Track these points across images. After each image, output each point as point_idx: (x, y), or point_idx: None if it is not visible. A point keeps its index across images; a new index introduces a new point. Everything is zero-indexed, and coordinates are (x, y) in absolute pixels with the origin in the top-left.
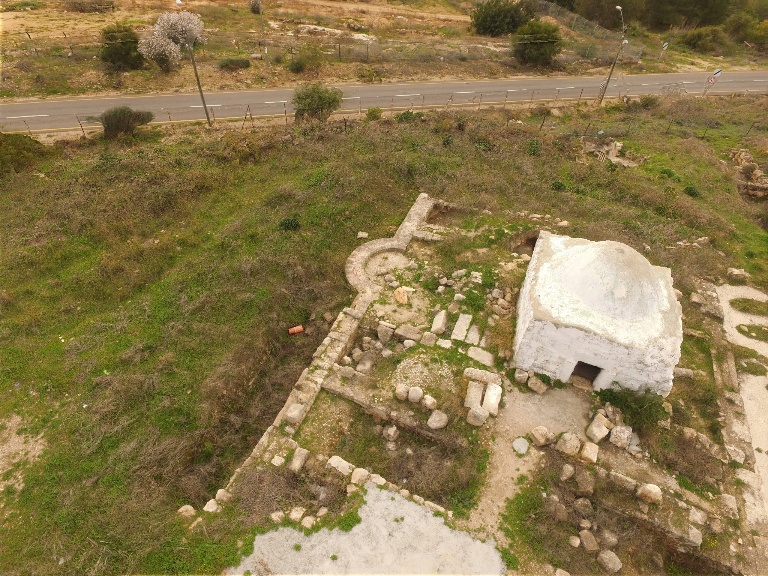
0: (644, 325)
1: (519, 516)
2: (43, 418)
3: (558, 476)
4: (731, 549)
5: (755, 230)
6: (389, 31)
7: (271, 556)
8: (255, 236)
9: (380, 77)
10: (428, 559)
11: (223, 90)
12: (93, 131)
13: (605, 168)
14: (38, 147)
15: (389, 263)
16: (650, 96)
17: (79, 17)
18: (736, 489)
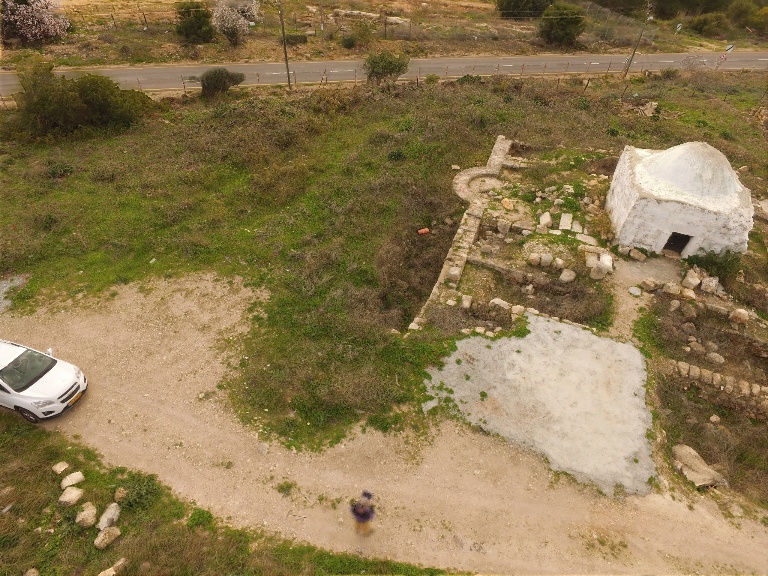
0: (726, 200)
1: (645, 330)
2: (260, 277)
3: (667, 308)
4: None
5: None
6: None
7: (472, 351)
8: (372, 164)
9: (423, 53)
10: (587, 352)
11: (289, 61)
12: (190, 91)
13: (649, 119)
14: (151, 102)
15: (487, 184)
16: (670, 69)
17: None
18: None
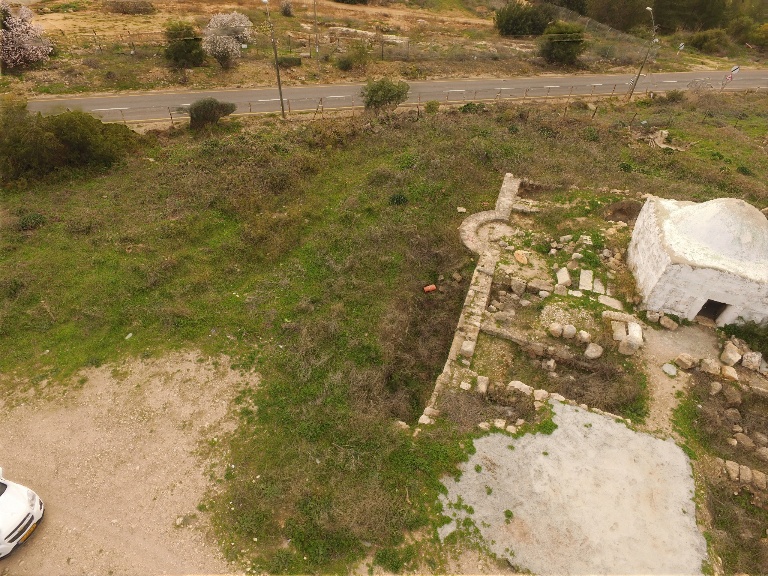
0: (767, 265)
1: (686, 421)
2: (250, 356)
3: (708, 392)
4: None
5: None
6: (423, 32)
7: (492, 454)
8: (372, 209)
9: (422, 75)
10: (623, 453)
11: (283, 86)
12: (178, 122)
13: (662, 151)
14: (135, 136)
15: (497, 232)
16: (676, 91)
17: (125, 18)
18: None
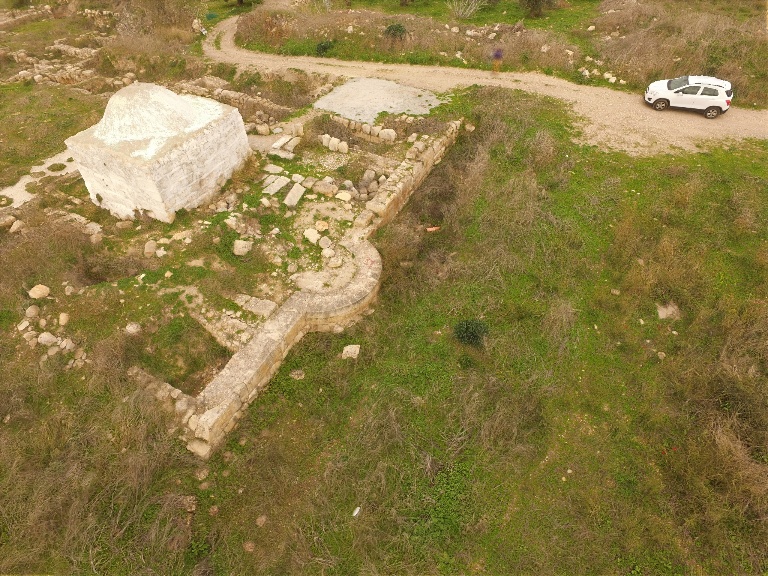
0: None
1: None
2: None
3: None
4: None
5: None
6: None
7: (421, 108)
8: (517, 307)
9: None
10: None
11: None
12: None
13: None
14: None
15: (323, 278)
16: None
17: None
18: None
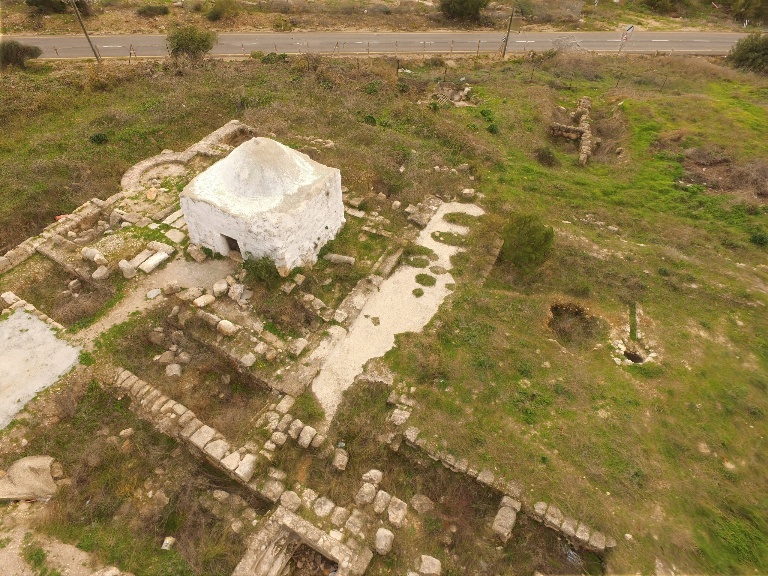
0: (261, 202)
1: (116, 335)
2: None
3: (167, 314)
4: (277, 372)
5: (527, 162)
6: None
7: None
8: None
9: (295, 27)
10: (24, 353)
11: (132, 34)
12: None
13: (426, 107)
14: None
15: (167, 172)
16: (552, 50)
17: None
18: (319, 338)
